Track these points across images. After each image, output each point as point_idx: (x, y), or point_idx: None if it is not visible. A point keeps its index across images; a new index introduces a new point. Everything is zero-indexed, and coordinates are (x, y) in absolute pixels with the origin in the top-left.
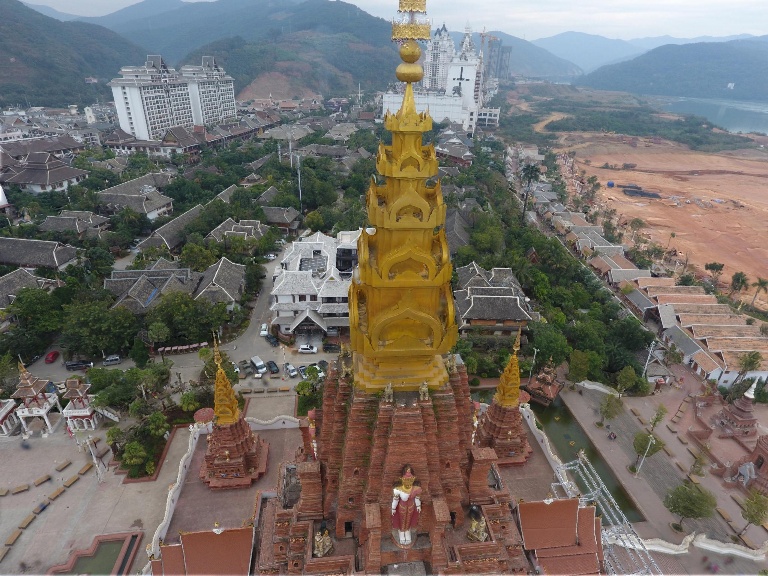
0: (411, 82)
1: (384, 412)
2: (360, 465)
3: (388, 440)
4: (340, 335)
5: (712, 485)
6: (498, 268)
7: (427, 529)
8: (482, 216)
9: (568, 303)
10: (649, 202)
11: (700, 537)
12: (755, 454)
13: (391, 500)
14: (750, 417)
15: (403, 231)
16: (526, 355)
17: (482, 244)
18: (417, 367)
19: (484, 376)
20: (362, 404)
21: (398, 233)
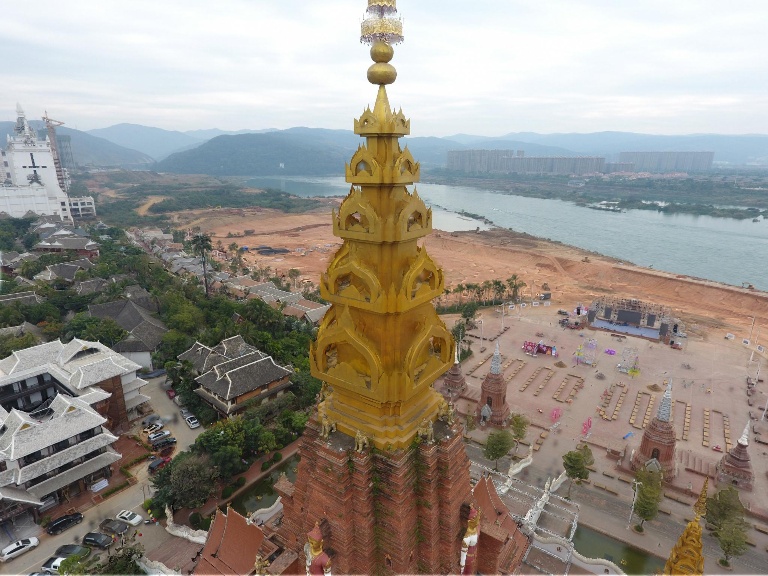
0: (386, 82)
1: (431, 458)
2: (415, 545)
3: (446, 486)
4: (62, 501)
5: (478, 434)
6: (227, 339)
7: (476, 569)
8: (167, 297)
9: (300, 349)
10: (284, 257)
11: (512, 467)
12: (485, 398)
13: (458, 558)
14: (461, 377)
15: (410, 242)
16: (305, 407)
17: (186, 324)
18: (425, 396)
19: (280, 447)
20: (404, 465)
21: (403, 246)
